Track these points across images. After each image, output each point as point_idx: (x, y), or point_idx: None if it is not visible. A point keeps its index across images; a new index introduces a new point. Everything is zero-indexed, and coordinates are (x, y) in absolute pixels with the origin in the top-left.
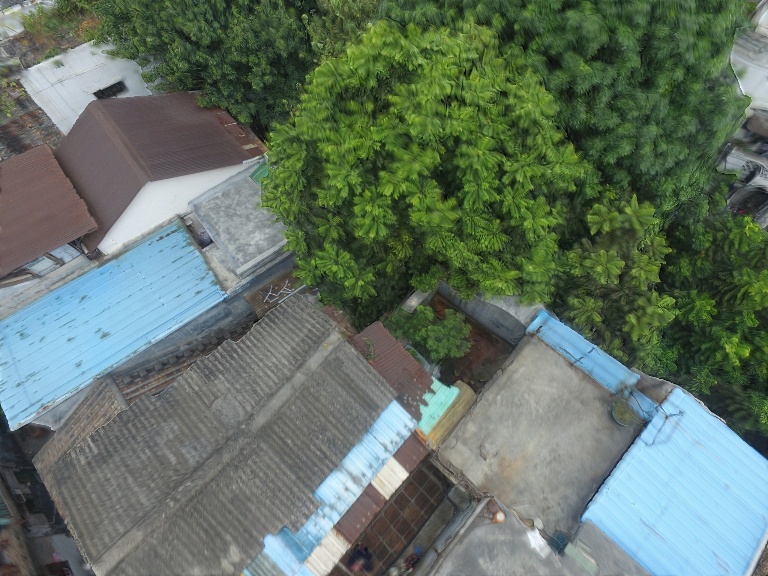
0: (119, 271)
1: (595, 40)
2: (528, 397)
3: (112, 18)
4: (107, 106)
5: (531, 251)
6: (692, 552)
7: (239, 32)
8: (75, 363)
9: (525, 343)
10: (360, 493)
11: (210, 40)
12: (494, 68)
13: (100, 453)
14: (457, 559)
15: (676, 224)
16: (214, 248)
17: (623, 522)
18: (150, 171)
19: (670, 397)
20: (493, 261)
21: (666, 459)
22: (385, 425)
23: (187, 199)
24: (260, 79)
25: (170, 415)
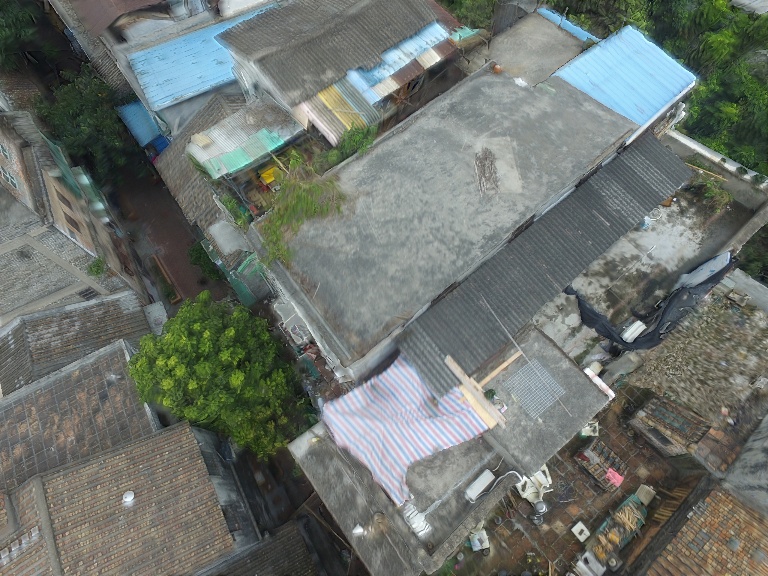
0: None
1: None
2: (526, 41)
3: None
4: None
5: None
6: (621, 101)
7: None
8: (197, 77)
9: (528, 16)
10: (408, 62)
11: None
12: None
13: (246, 28)
14: (467, 87)
15: (662, 9)
16: None
17: (577, 81)
18: None
19: (622, 29)
20: None
21: (613, 56)
22: (428, 33)
23: None
24: None
25: (290, 14)
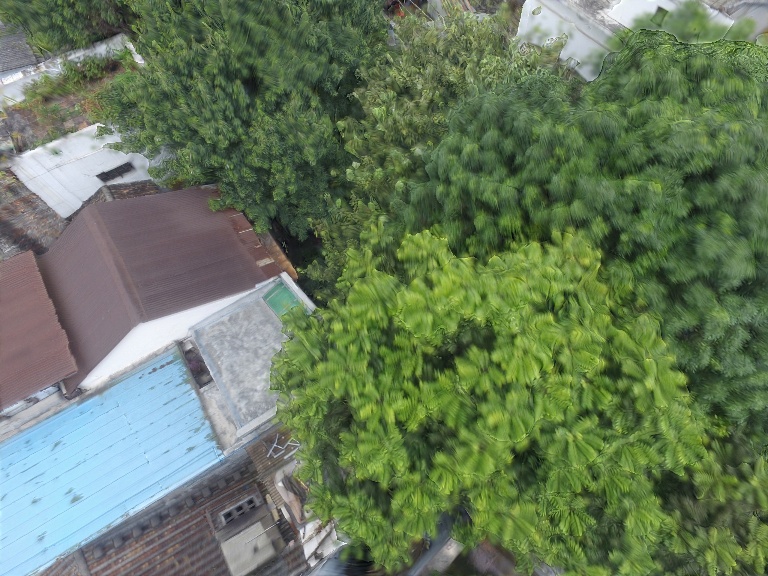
0: (102, 411)
1: (737, 277)
2: None
3: (118, 108)
4: (104, 212)
5: (619, 535)
6: None
7: (262, 139)
8: (38, 535)
9: None
10: None
11: (228, 143)
12: (590, 294)
13: None
14: None
15: None
16: (214, 388)
17: None
18: (144, 307)
19: None
20: (566, 541)
21: None
22: None
23: (188, 325)
24: (283, 187)
25: None
